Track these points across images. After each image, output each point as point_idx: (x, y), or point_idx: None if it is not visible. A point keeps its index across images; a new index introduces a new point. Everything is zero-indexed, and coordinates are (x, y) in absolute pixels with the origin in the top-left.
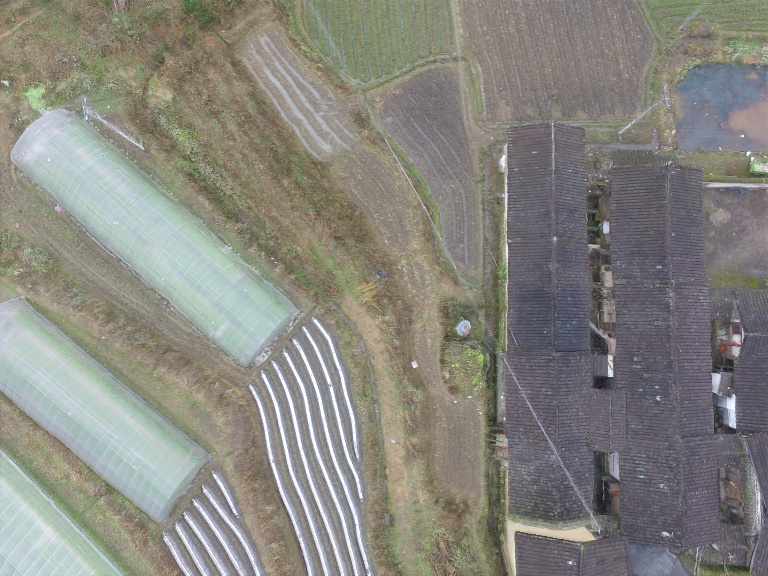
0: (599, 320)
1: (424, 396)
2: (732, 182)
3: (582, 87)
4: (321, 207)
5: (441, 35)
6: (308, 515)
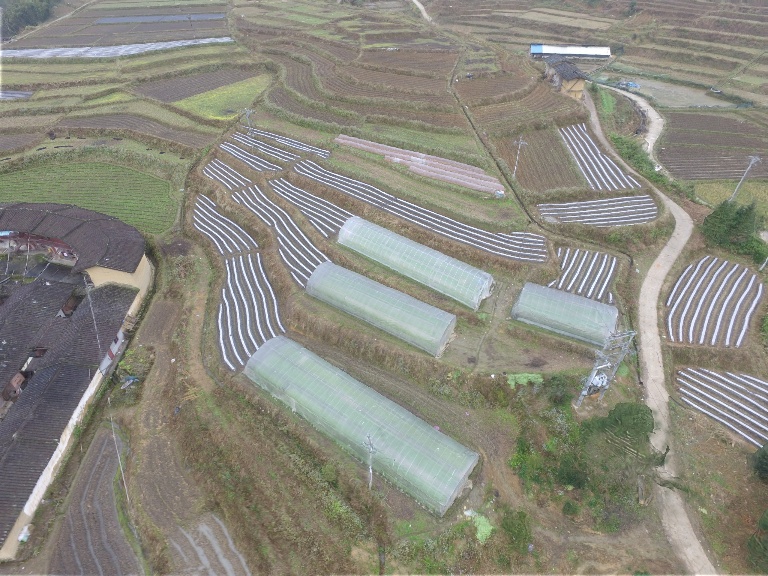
0: None
1: None
2: None
3: None
4: None
5: None
6: (256, 281)
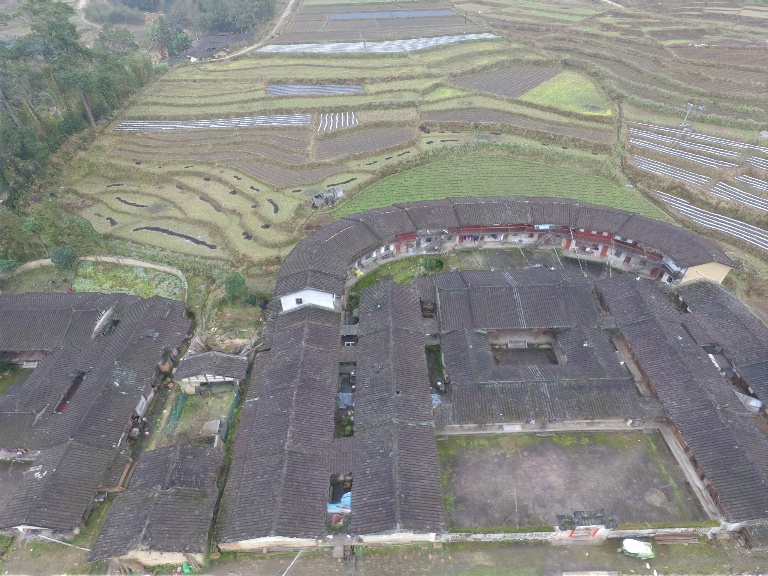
0: None
1: None
2: None
3: None
4: None
5: None
6: None
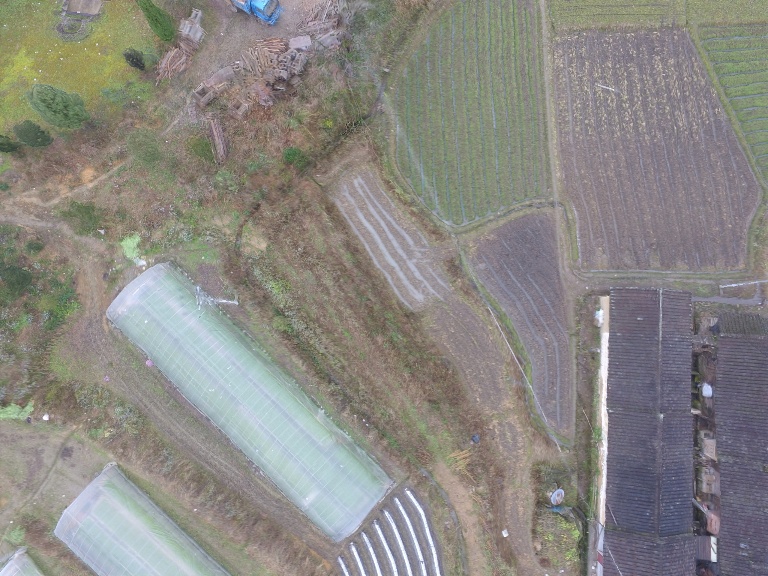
0: (696, 487)
1: (516, 571)
2: None
3: (682, 236)
4: (416, 369)
5: (537, 178)
6: None
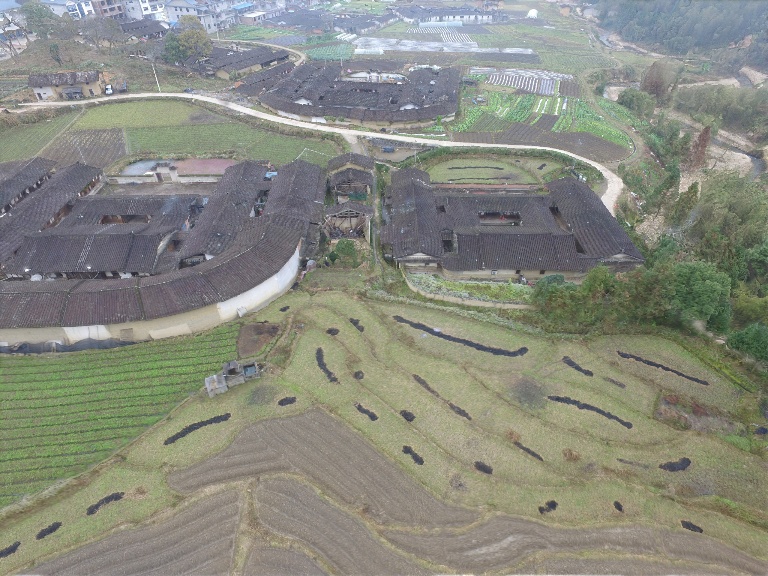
0: None
1: None
2: (123, 177)
3: None
4: None
5: None
6: None
